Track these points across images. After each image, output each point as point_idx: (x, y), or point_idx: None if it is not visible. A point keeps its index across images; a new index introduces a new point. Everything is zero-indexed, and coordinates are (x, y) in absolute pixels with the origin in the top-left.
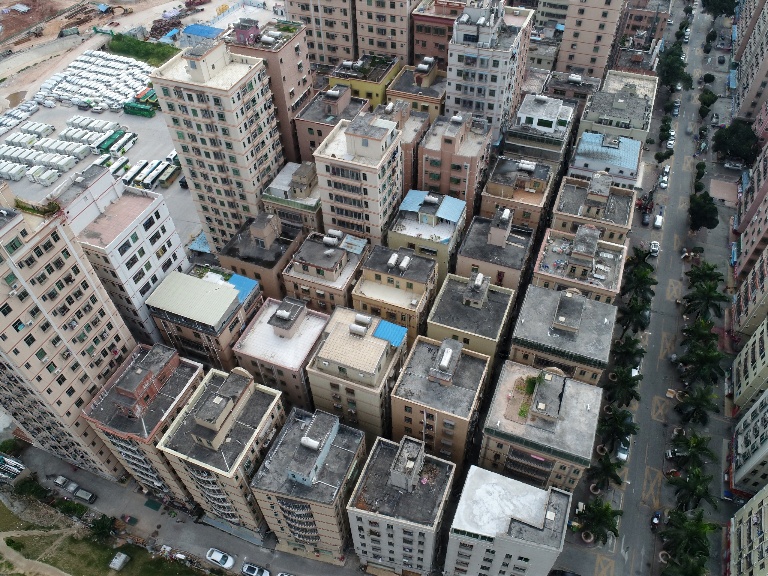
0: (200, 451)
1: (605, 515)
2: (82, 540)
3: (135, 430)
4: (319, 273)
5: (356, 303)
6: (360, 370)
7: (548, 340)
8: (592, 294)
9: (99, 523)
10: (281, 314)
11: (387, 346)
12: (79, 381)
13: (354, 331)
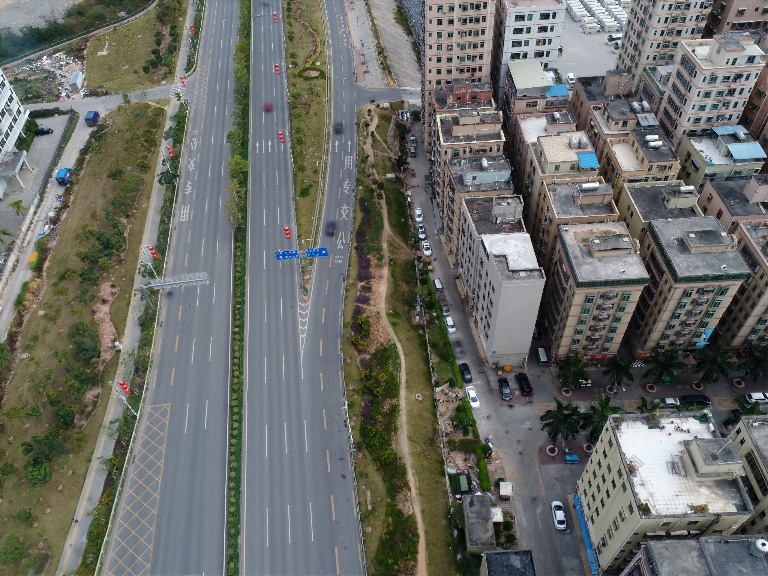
0: (448, 131)
1: (575, 363)
2: (392, 162)
3: (440, 107)
4: (608, 120)
5: (605, 150)
6: (546, 156)
7: (666, 239)
8: (760, 269)
9: (402, 158)
10: (555, 114)
11: (575, 161)
12: (446, 71)
13: (570, 141)
